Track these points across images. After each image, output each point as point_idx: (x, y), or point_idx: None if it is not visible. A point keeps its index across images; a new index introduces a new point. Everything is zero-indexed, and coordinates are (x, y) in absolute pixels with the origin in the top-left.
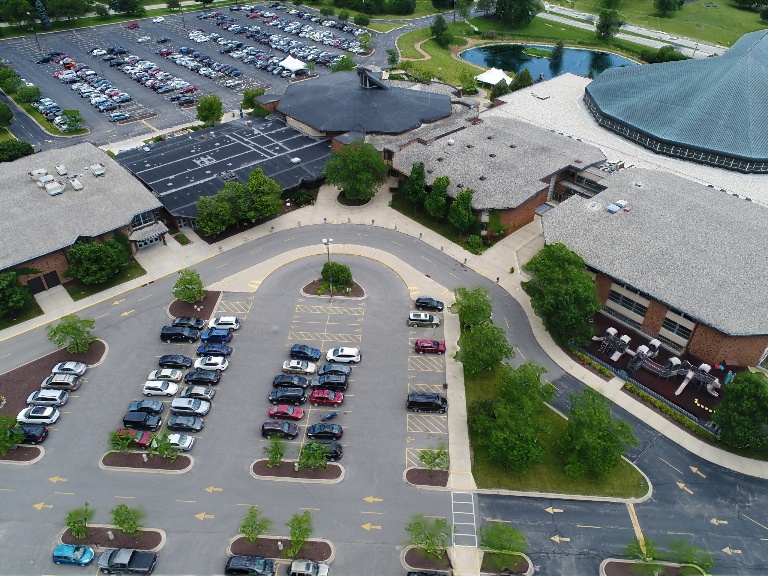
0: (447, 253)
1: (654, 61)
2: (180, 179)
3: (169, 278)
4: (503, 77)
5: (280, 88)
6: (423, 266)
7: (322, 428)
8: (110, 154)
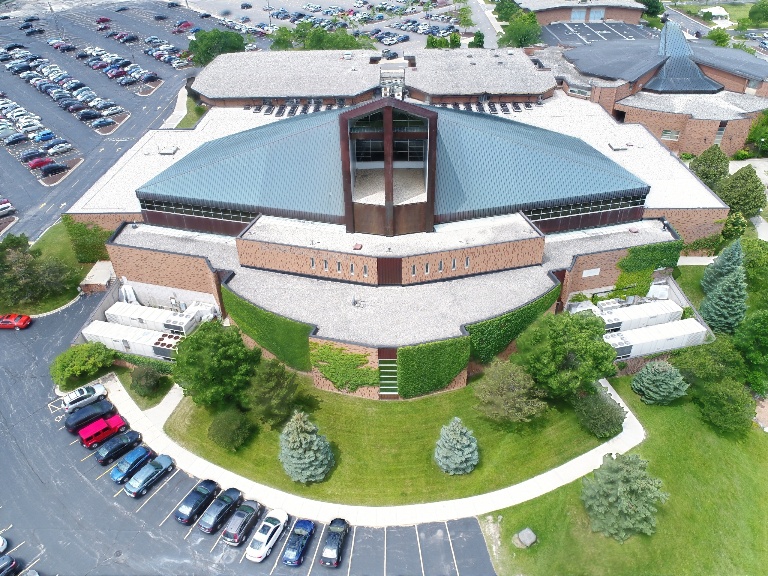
0: None
1: None
2: None
3: (495, 34)
4: None
5: None
6: None
7: None
8: None
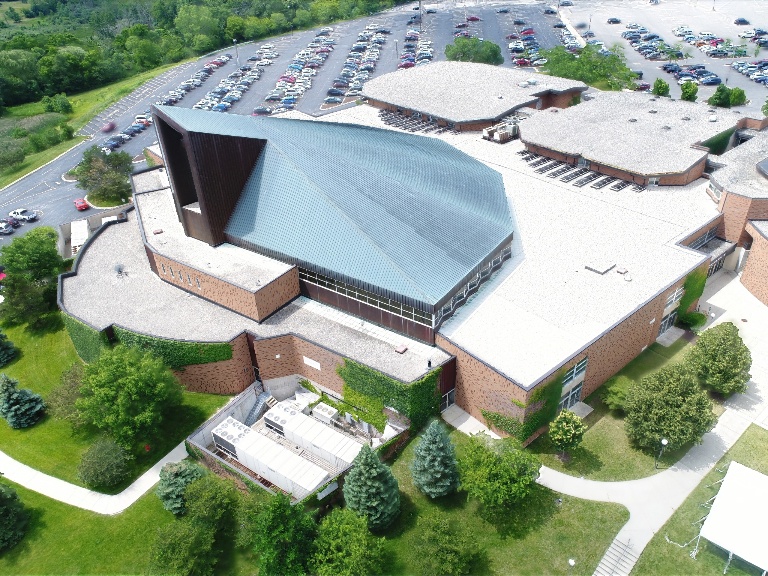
0: None
1: None
2: None
3: None
4: None
5: None
6: None
7: (676, 67)
8: None
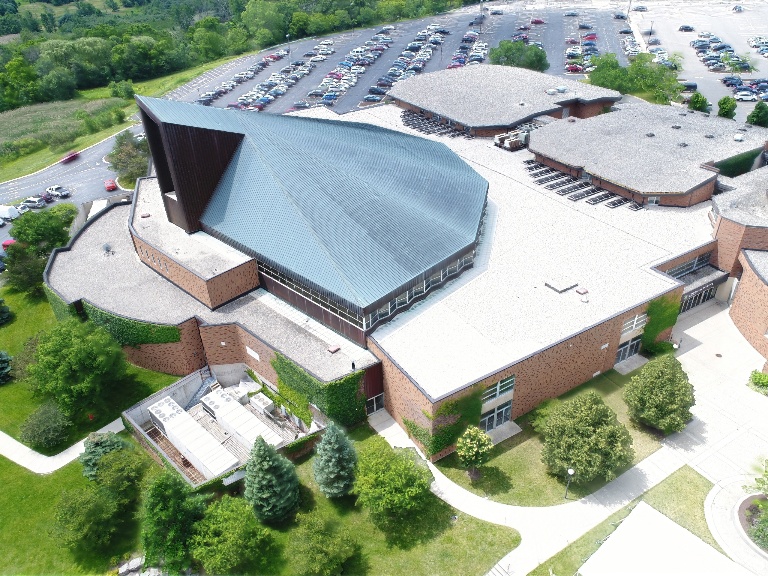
0: None
1: None
2: None
3: None
4: (658, 545)
5: None
6: None
7: None
8: None
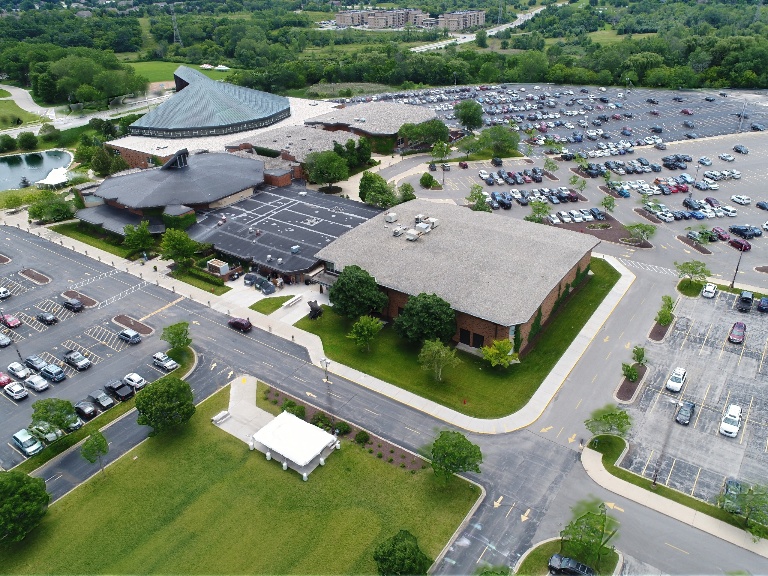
0: (383, 168)
1: (4, 150)
2: (351, 222)
3: None
4: None
5: (33, 263)
6: (398, 172)
7: (529, 171)
8: (262, 301)
